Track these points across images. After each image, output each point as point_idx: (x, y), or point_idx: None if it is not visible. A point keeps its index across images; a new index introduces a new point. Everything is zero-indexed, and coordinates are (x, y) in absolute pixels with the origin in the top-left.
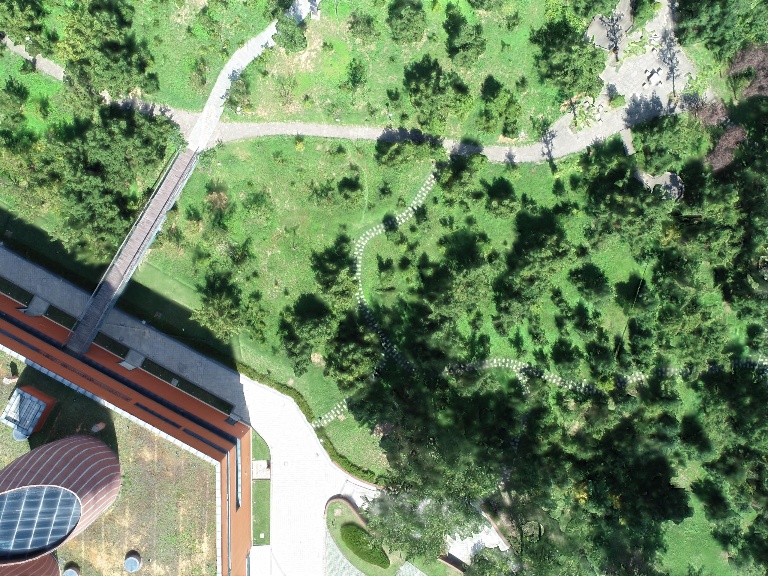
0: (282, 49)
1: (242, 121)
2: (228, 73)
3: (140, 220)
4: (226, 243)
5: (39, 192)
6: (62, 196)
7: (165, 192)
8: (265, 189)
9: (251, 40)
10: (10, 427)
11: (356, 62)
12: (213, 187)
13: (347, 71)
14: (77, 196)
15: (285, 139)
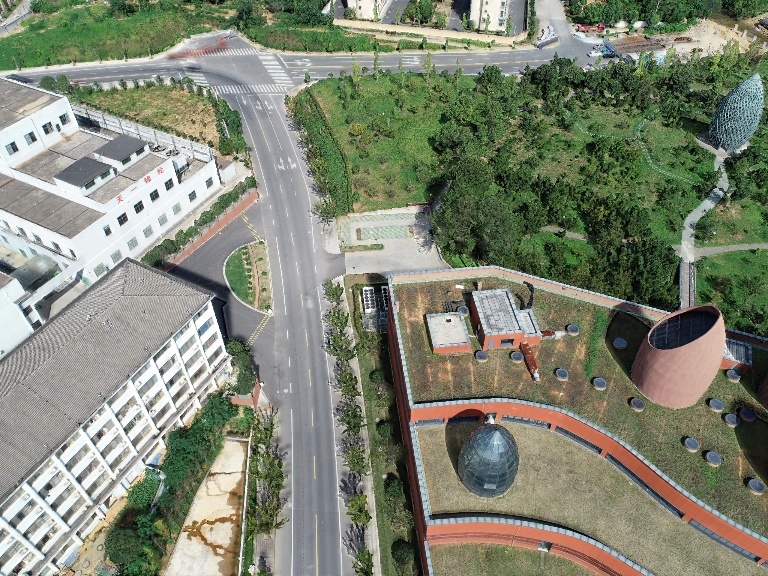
0: (717, 210)
1: (710, 246)
2: (688, 226)
3: (679, 296)
4: (739, 310)
5: (622, 273)
6: (632, 277)
7: (685, 282)
8: (746, 278)
9: (694, 210)
10: (720, 375)
11: (764, 213)
12: (710, 281)
13: (761, 218)
14: (649, 272)
15: (743, 252)
